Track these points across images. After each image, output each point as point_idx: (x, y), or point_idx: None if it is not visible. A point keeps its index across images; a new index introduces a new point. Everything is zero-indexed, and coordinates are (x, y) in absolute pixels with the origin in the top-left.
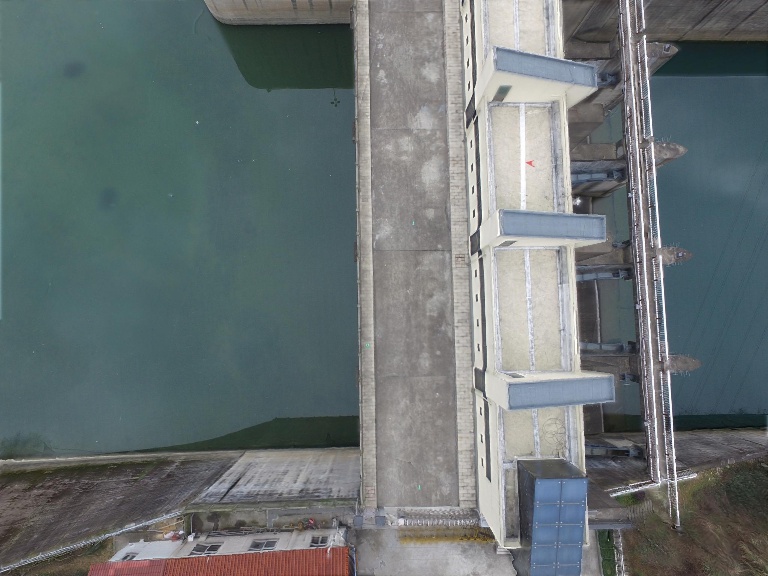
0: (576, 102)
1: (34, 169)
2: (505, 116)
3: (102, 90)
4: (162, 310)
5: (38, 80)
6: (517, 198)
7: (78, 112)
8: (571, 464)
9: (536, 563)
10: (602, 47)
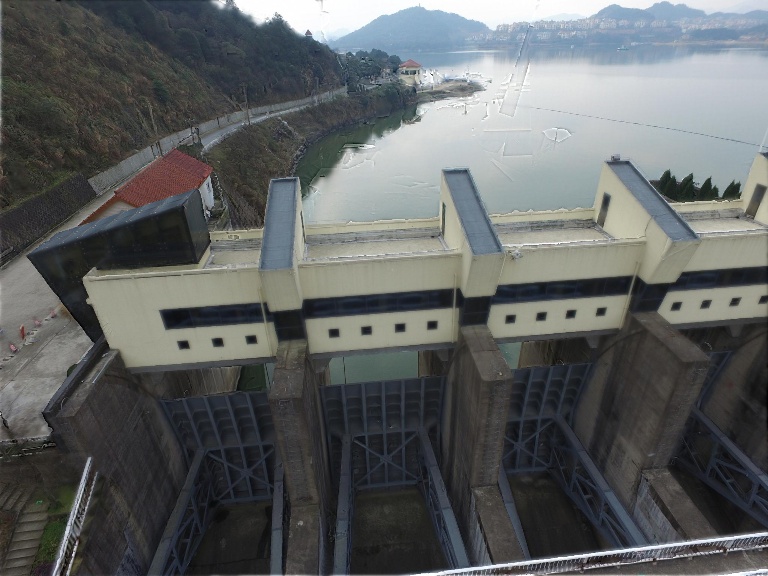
0: (654, 267)
1: None
2: (590, 234)
3: None
4: None
5: None
6: (502, 243)
7: None
8: (194, 243)
9: (105, 219)
10: None
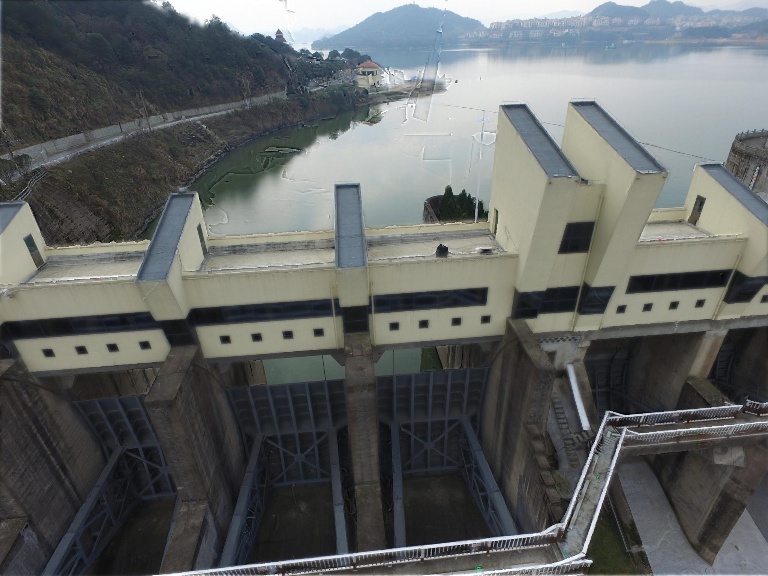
0: None
1: None
2: None
3: None
4: None
5: None
6: None
7: None
8: None
9: None
10: None
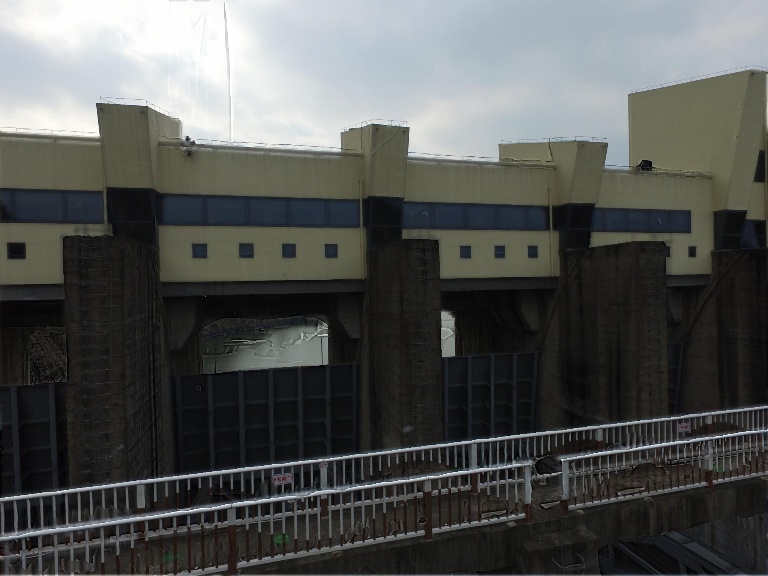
0: None
1: None
2: None
3: None
4: None
5: None
6: None
7: None
8: None
9: None
10: None
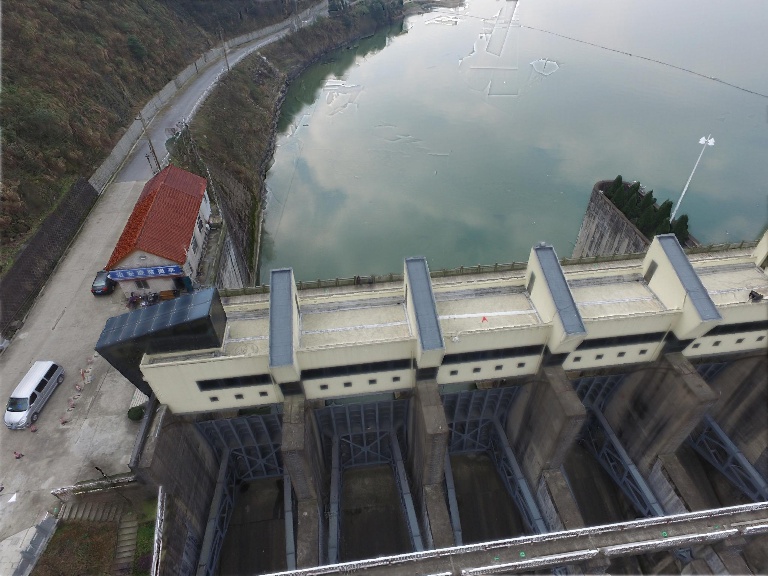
0: None
1: (433, 211)
2: (520, 302)
3: (493, 228)
4: (353, 265)
5: (487, 207)
6: (451, 313)
7: (474, 222)
8: None
9: (145, 310)
10: (705, 509)
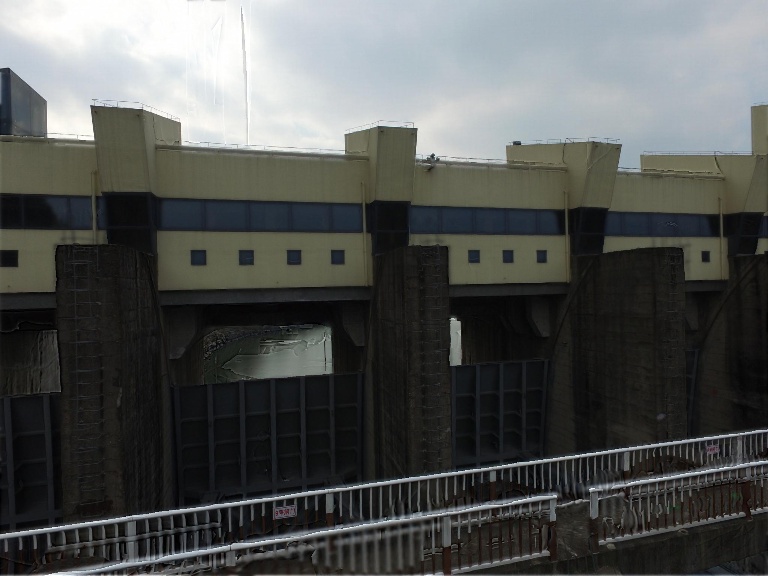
0: (583, 183)
1: None
2: None
3: None
4: None
5: None
6: None
7: None
8: (15, 122)
9: None
10: None
